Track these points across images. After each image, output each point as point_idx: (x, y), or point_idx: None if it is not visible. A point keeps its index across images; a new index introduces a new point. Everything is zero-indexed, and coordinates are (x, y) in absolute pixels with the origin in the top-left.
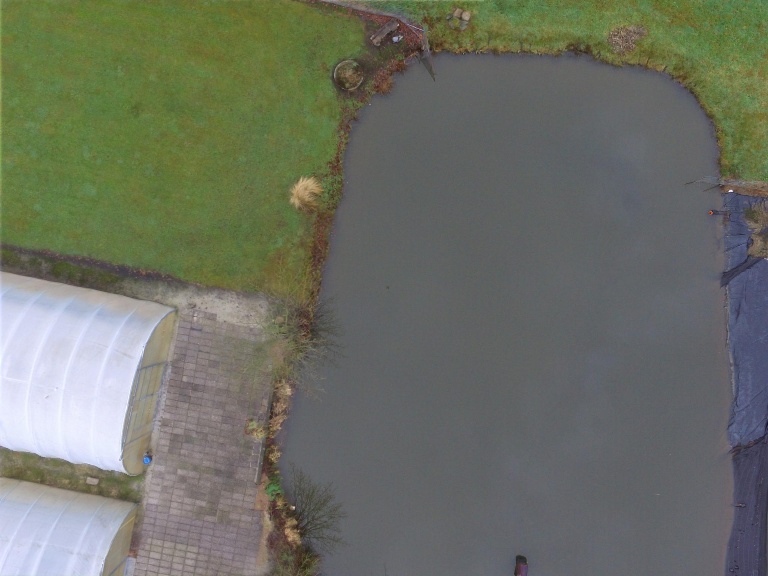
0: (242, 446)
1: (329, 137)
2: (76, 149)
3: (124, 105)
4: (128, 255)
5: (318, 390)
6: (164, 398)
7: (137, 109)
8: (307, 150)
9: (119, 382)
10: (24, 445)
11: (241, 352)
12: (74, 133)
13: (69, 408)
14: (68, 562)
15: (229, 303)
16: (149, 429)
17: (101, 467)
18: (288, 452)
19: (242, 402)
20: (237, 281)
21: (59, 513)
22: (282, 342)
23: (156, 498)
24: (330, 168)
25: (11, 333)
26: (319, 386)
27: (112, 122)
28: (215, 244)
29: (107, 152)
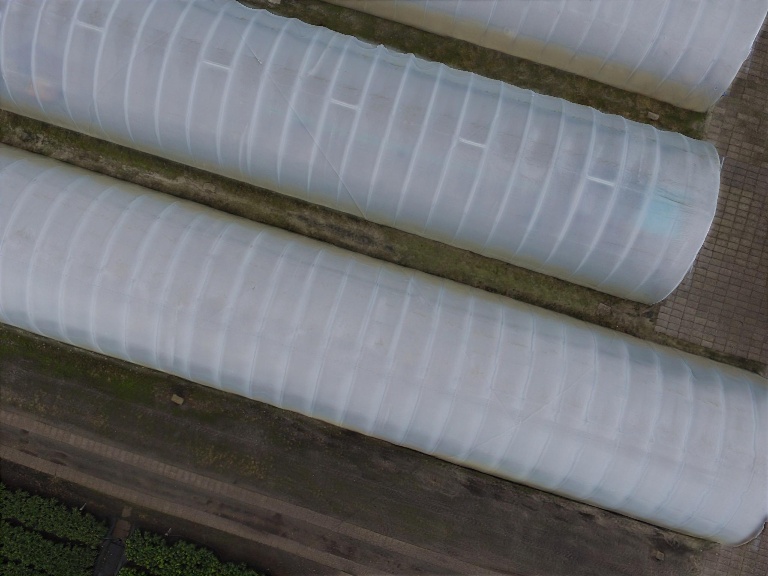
0: None
1: None
2: None
3: None
4: None
5: None
6: None
7: None
8: None
9: None
10: (636, 44)
11: None
12: None
13: None
14: (685, 156)
15: None
16: None
17: (699, 81)
18: None
19: None
20: None
21: (650, 125)
22: None
23: (714, 140)
24: None
25: None
26: None
27: None
28: None
29: None
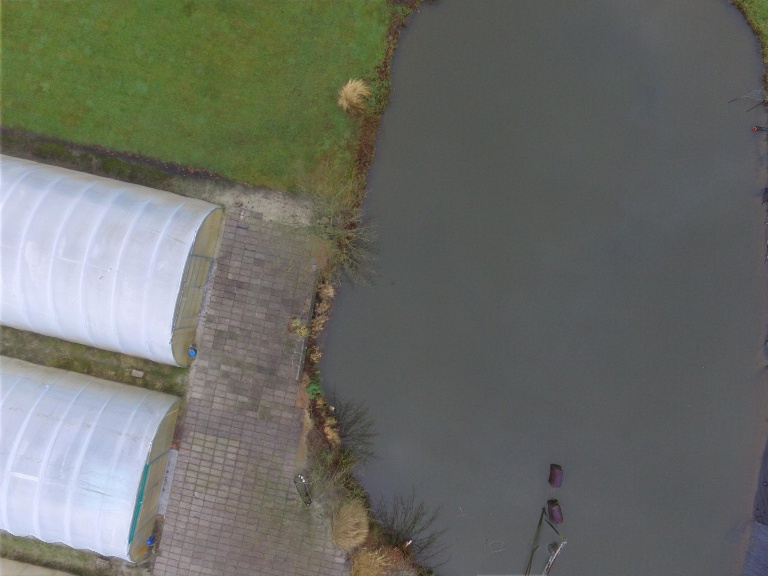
0: (285, 344)
1: (378, 42)
2: (129, 47)
3: (177, 4)
4: (177, 153)
5: (369, 272)
6: (209, 294)
7: (189, 9)
8: (356, 54)
9: (171, 265)
10: (75, 328)
11: (286, 251)
12: (127, 31)
13: (122, 289)
14: (117, 442)
15: (275, 203)
16: (195, 323)
17: (149, 354)
18: (329, 353)
19: (286, 301)
20: (284, 181)
21: (107, 399)
22: (327, 243)
23: (199, 392)
24: (378, 73)
25: (66, 216)
26: (371, 267)
27: (164, 21)
28: (263, 144)
29: (159, 50)
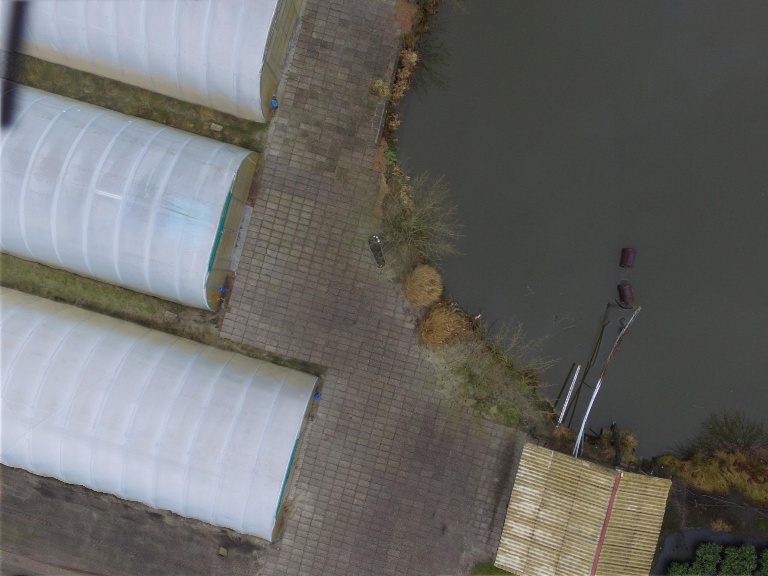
0: (365, 106)
1: None
2: None
3: None
4: None
5: None
6: (293, 52)
7: None
8: None
9: None
10: (164, 59)
11: (372, 13)
12: None
13: (217, 11)
14: (201, 169)
15: None
16: (277, 77)
17: (234, 94)
18: (408, 122)
19: (369, 62)
20: None
21: (189, 138)
22: (412, 7)
23: (277, 150)
24: None
25: None
26: None
27: None
28: None
29: None
